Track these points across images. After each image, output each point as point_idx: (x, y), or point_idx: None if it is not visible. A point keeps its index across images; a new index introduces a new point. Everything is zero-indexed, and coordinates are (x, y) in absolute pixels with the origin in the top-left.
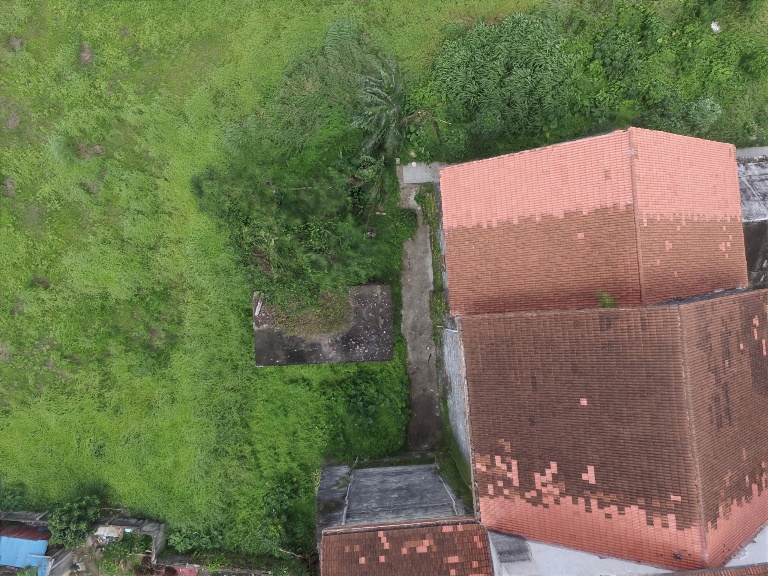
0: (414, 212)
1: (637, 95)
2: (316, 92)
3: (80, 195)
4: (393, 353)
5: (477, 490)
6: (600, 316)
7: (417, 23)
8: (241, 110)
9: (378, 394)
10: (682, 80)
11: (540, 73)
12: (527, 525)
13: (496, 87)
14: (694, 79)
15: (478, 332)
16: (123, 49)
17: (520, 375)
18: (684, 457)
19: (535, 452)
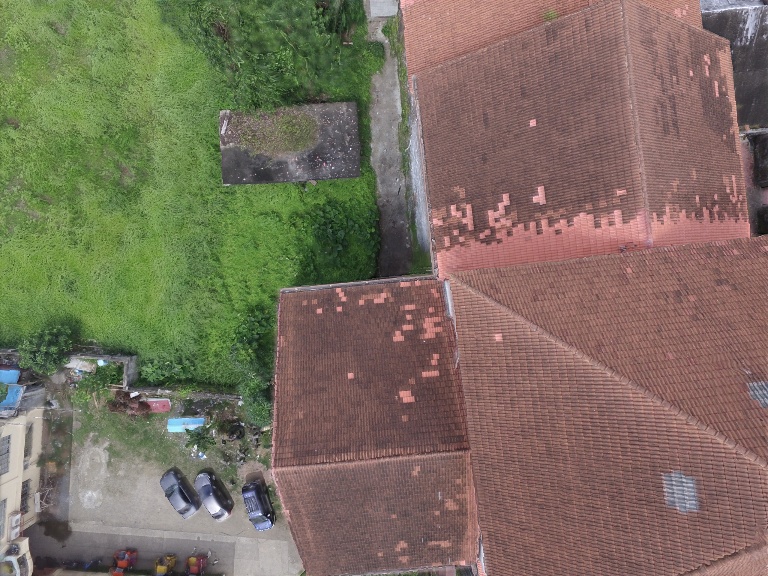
0: (381, 44)
1: None
2: None
3: (48, 33)
4: (361, 179)
5: (435, 247)
6: (547, 30)
7: None
8: None
9: (347, 220)
10: None
11: None
12: (482, 267)
13: None
14: None
15: (432, 85)
16: None
17: (473, 116)
18: (629, 148)
19: (488, 189)
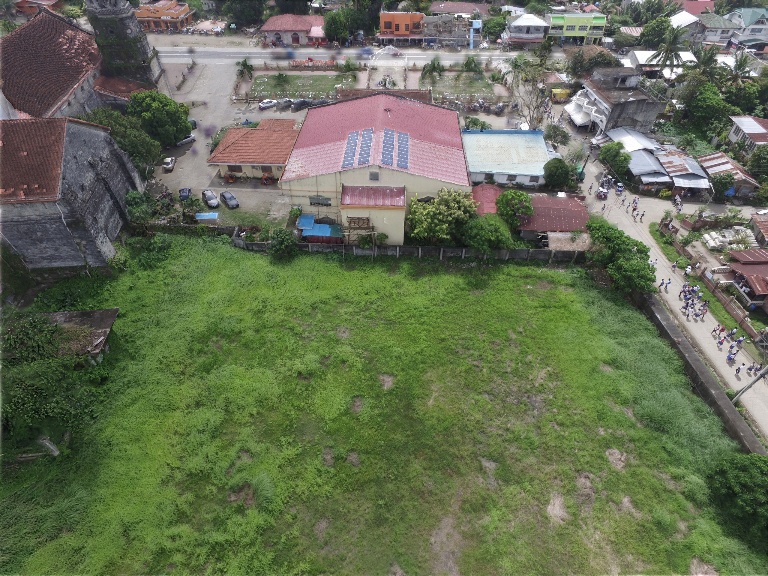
0: None
1: None
2: None
3: (254, 446)
4: None
5: None
6: None
7: None
8: (61, 544)
9: None
10: None
11: None
12: None
13: None
14: None
15: None
16: None
17: None
18: None
19: None
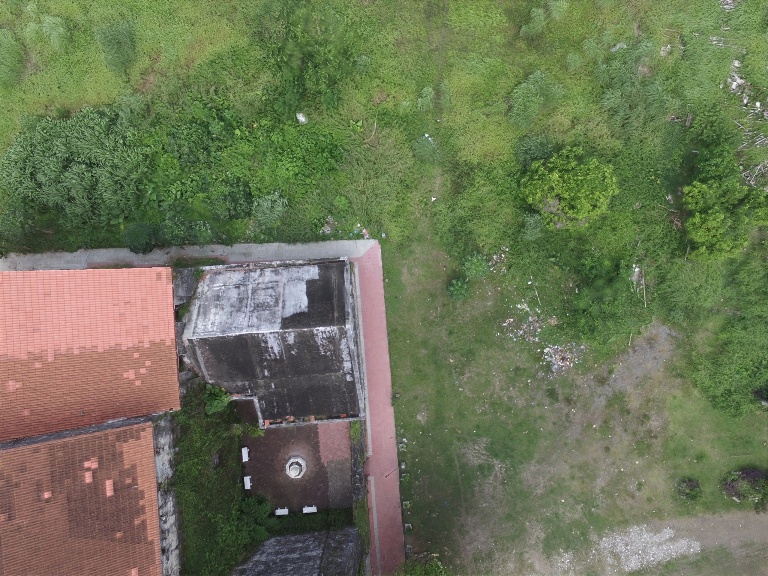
0: None
1: None
2: None
3: None
4: None
5: None
6: None
7: None
8: None
9: None
10: (259, 173)
11: (98, 169)
12: None
13: (51, 183)
14: (269, 172)
15: None
16: None
17: None
18: None
19: None
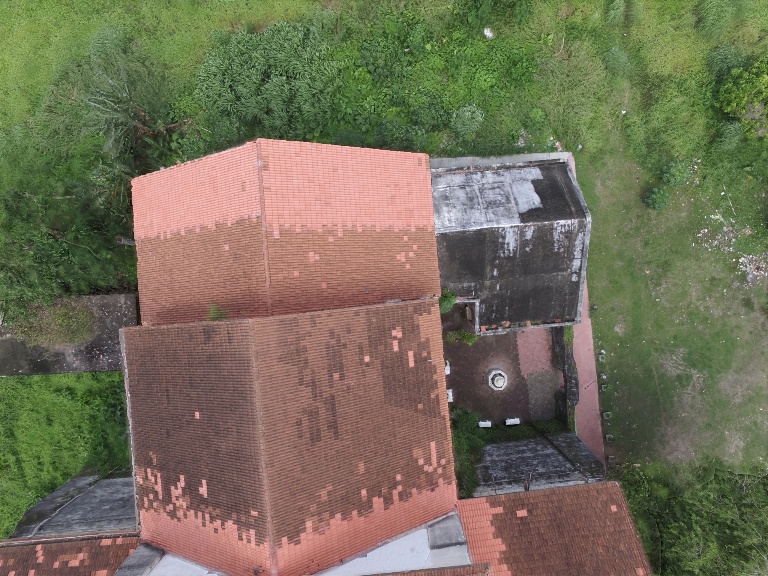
0: None
1: (404, 102)
2: (81, 101)
3: None
4: None
5: (138, 503)
6: (203, 329)
7: (186, 31)
8: (10, 119)
9: None
10: (451, 87)
11: (298, 81)
12: (169, 539)
13: (252, 95)
14: (462, 86)
15: (133, 344)
16: None
17: (159, 388)
18: (258, 472)
19: (170, 465)
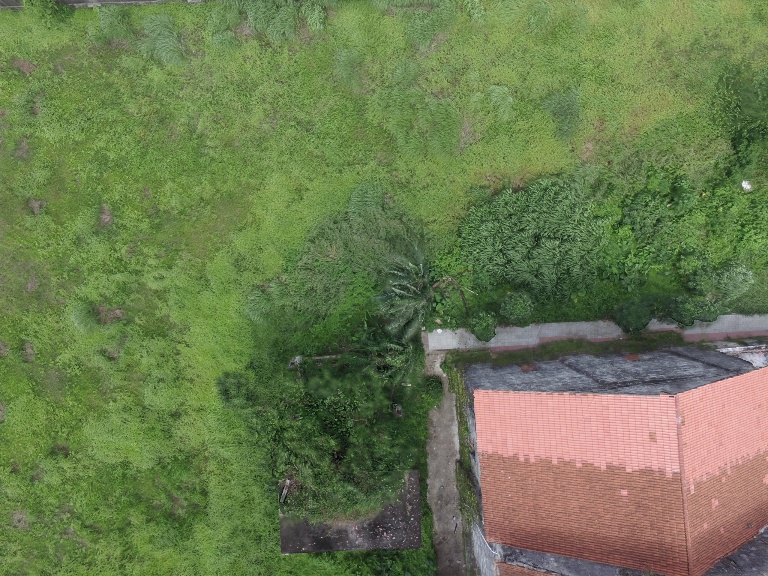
0: (440, 380)
1: (667, 260)
2: (340, 258)
3: (101, 362)
4: None
5: None
6: None
7: (442, 185)
8: (263, 274)
9: (404, 572)
10: (712, 243)
11: (569, 244)
12: None
13: (524, 260)
14: (725, 243)
15: None
16: (143, 211)
17: None
18: None
19: None
